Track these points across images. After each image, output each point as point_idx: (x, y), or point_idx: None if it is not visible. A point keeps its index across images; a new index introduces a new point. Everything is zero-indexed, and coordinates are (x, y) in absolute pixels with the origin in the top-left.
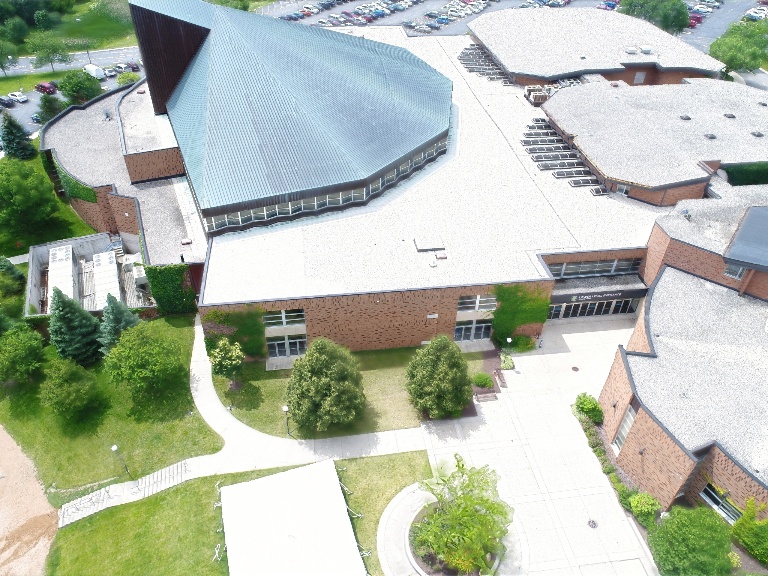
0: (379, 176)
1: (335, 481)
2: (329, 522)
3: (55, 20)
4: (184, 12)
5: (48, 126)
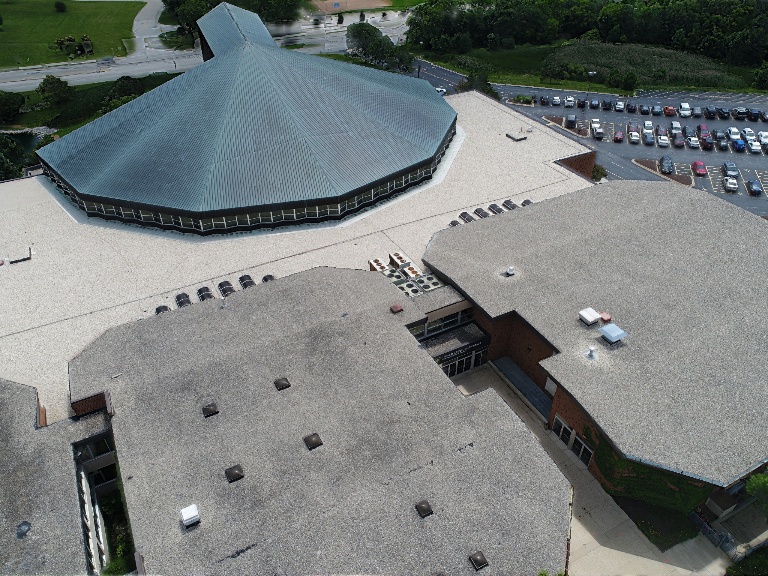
0: (99, 201)
1: None
2: None
3: (505, 45)
4: (217, 39)
5: None
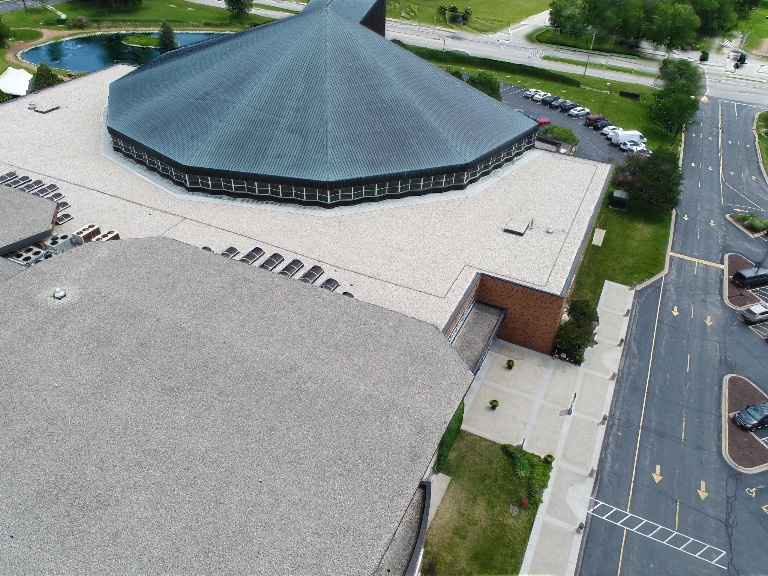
0: None
1: None
2: (9, 86)
3: None
4: None
5: None
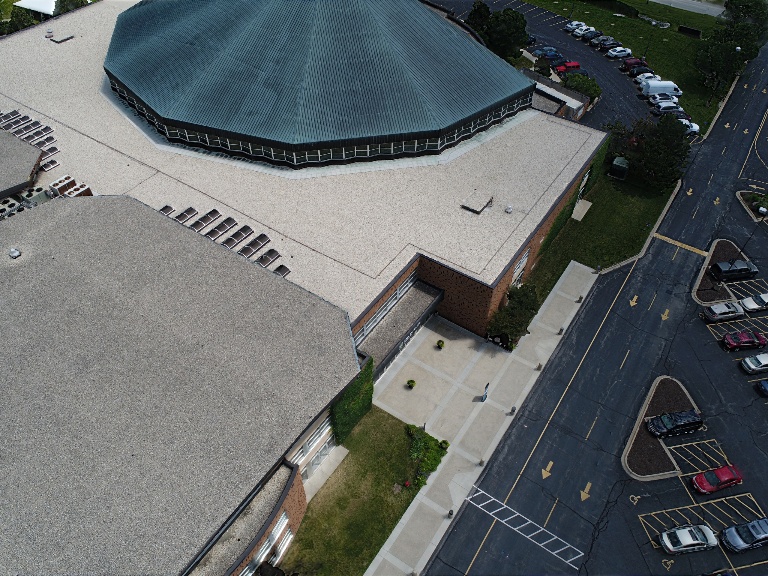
0: None
1: (51, 13)
2: (41, 4)
3: None
4: None
5: (425, 2)
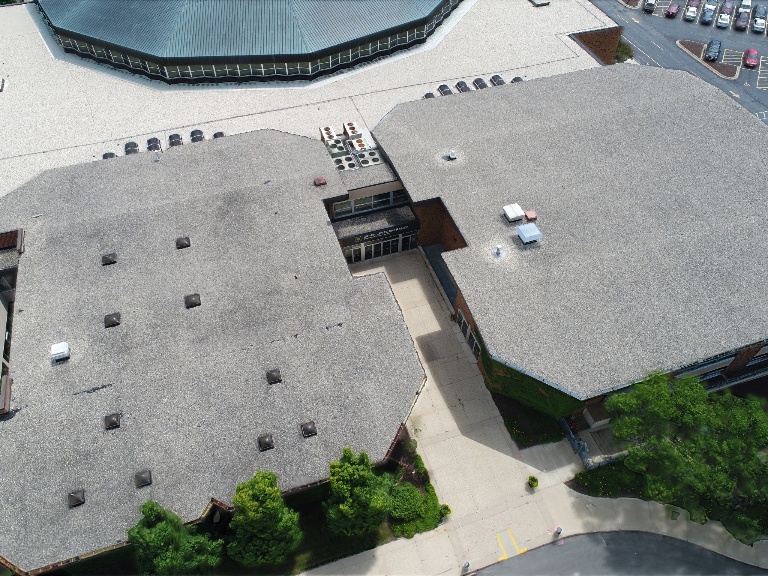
0: (72, 36)
1: None
2: None
3: None
4: None
5: None
